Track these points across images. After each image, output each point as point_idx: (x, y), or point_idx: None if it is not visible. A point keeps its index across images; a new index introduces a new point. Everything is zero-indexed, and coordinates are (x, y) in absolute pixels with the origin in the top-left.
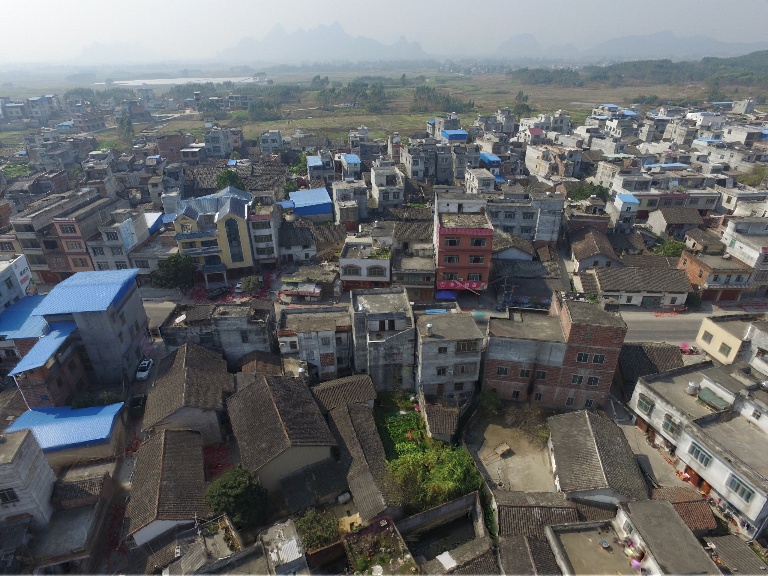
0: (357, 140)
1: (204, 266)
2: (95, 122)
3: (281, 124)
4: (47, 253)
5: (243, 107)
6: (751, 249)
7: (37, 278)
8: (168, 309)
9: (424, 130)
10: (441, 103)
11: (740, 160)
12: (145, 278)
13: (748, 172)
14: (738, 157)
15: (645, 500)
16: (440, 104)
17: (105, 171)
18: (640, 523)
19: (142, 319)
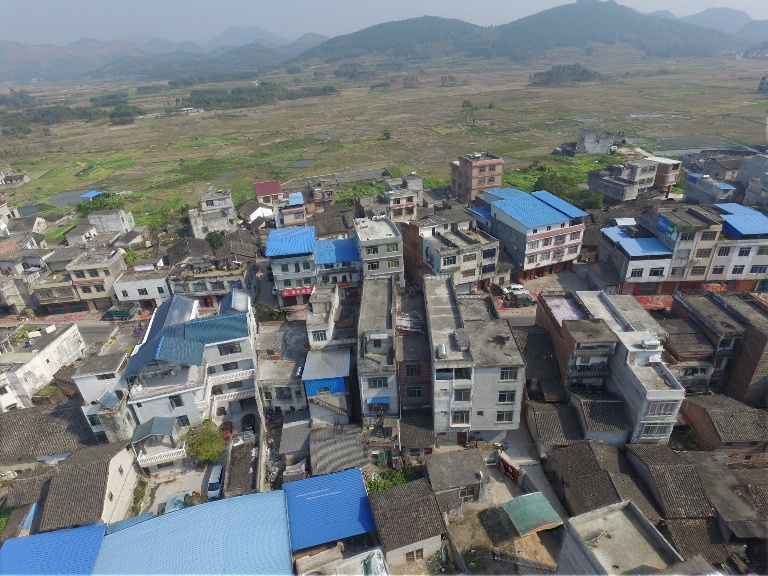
0: None
1: None
2: None
3: None
4: None
5: None
6: None
7: None
8: None
9: None
10: None
11: None
12: None
13: None
14: None
15: (73, 234)
16: None
17: None
18: None
19: None
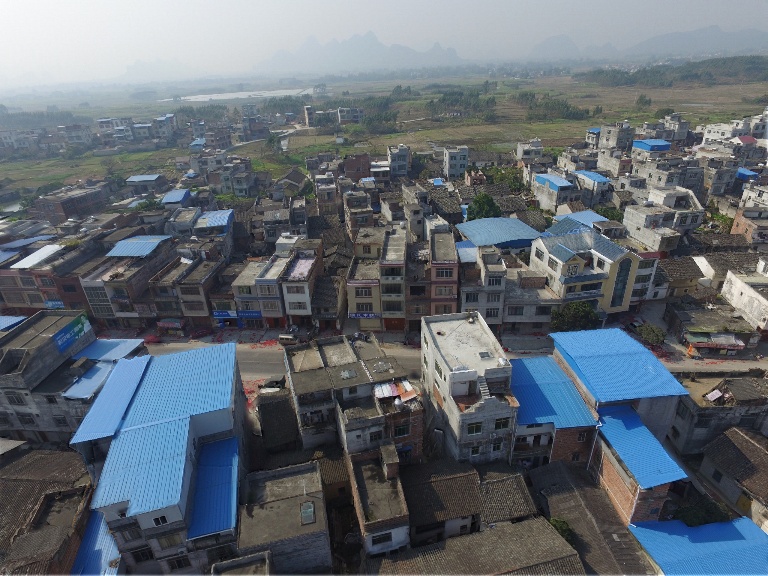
0: (578, 155)
1: None
2: (224, 140)
3: (405, 137)
4: (410, 299)
5: (353, 120)
6: None
7: (378, 325)
8: None
9: (569, 139)
10: (557, 110)
11: None
12: (507, 325)
13: None
14: None
15: None
16: (556, 111)
17: (365, 198)
18: None
19: None
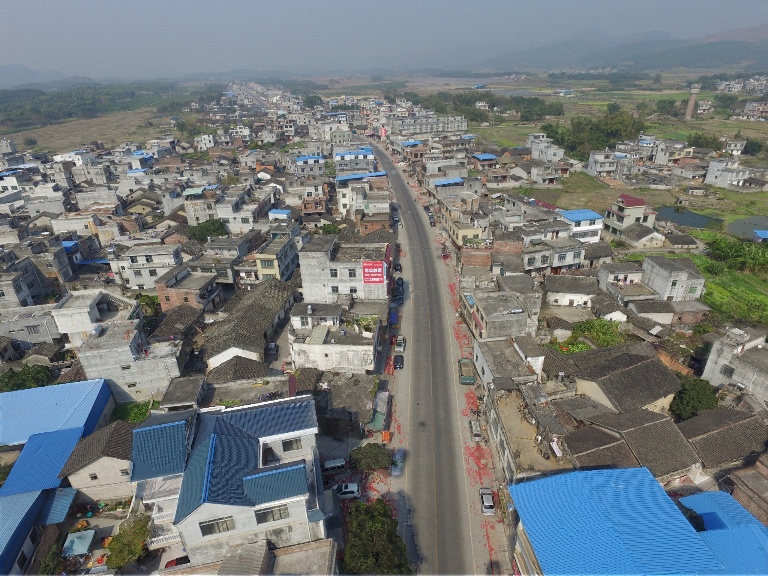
0: None
1: (332, 517)
2: None
3: None
4: None
5: None
6: (382, 204)
7: None
8: None
9: None
10: None
11: (202, 176)
12: None
13: (214, 182)
14: (198, 174)
15: None
16: None
17: None
18: (619, 270)
19: None
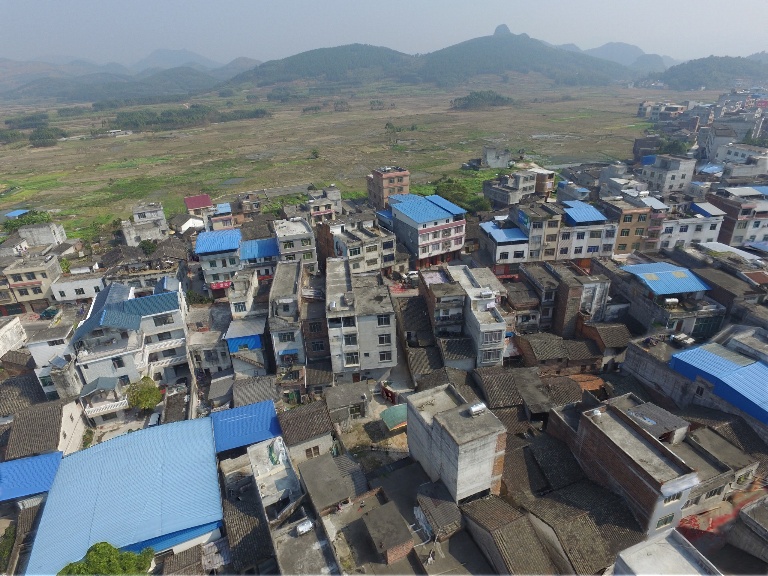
0: None
1: None
2: None
3: None
4: None
5: None
6: None
7: None
8: None
9: None
10: None
11: None
12: None
13: None
14: None
15: (4, 247)
16: None
17: None
18: None
19: None
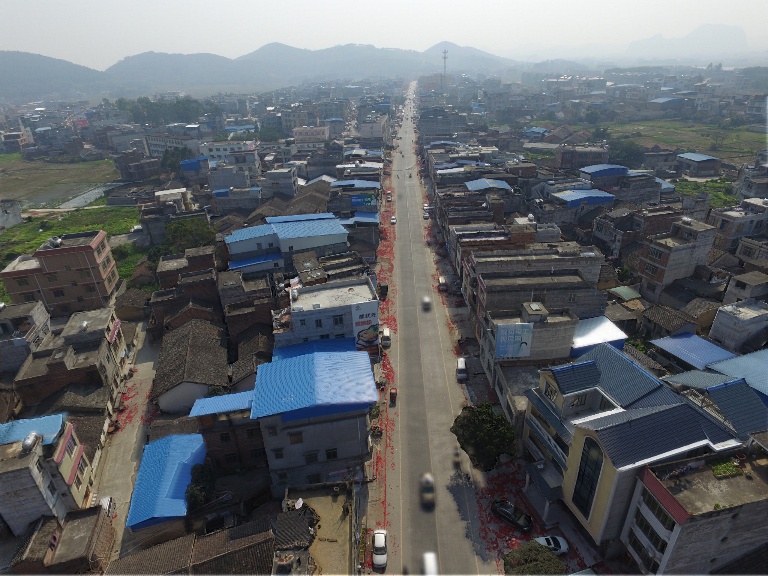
0: None
1: None
2: None
3: None
4: None
5: None
6: None
7: None
8: (452, 462)
9: None
10: None
11: None
12: None
13: None
14: None
15: None
16: None
17: (697, 234)
18: None
19: (352, 452)
